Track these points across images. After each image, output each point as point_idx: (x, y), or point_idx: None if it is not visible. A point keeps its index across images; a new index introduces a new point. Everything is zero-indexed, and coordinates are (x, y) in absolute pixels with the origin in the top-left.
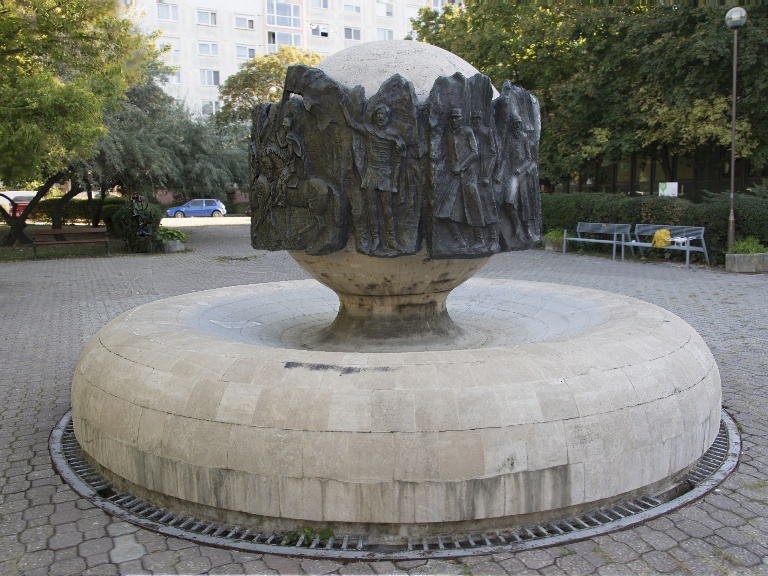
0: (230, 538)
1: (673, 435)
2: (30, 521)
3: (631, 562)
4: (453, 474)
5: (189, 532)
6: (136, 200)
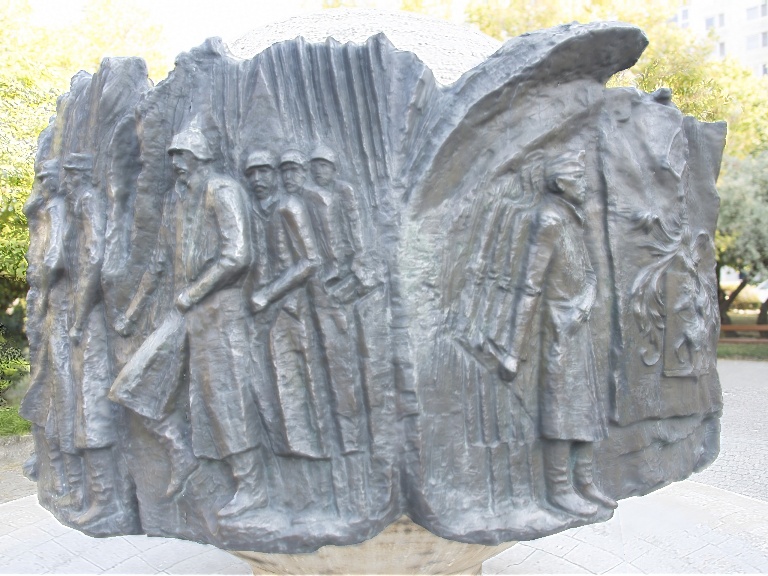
0: None
1: None
2: None
3: None
4: None
5: None
6: None
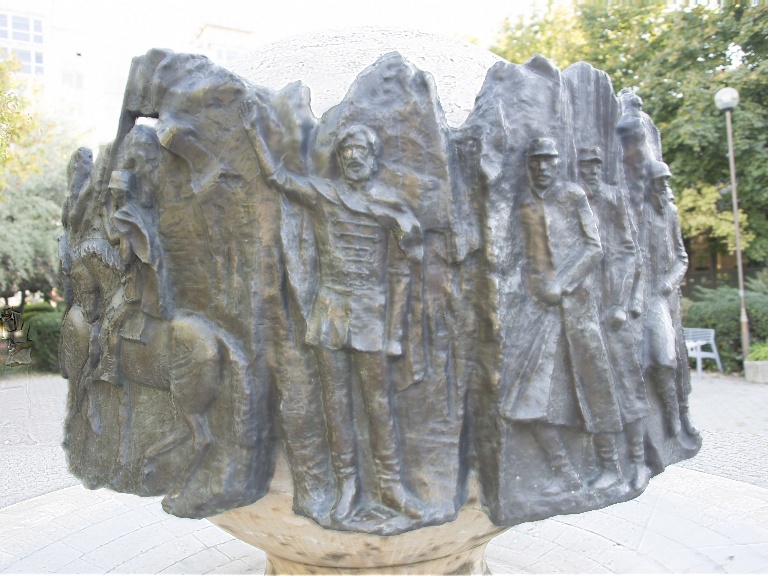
0: None
1: None
2: None
3: None
4: None
5: None
6: (6, 318)
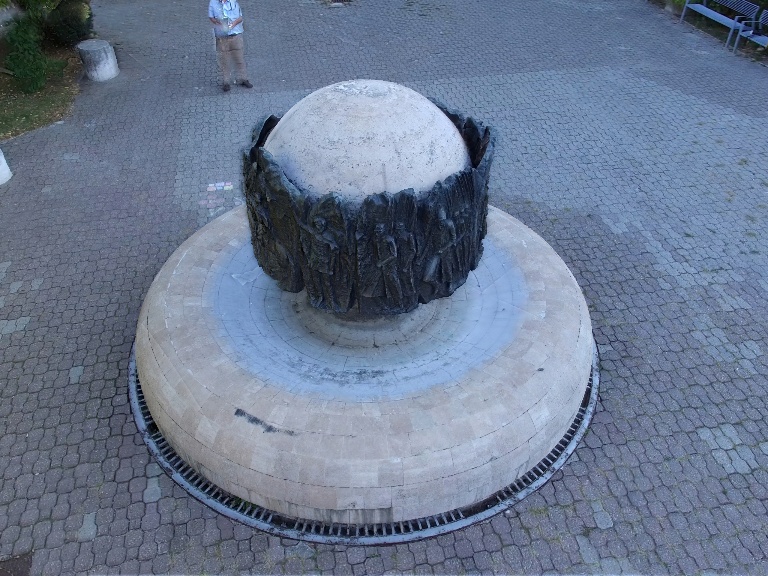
0: (206, 494)
1: (480, 485)
2: (109, 451)
3: (406, 571)
4: (318, 505)
5: (187, 482)
6: (225, 1)
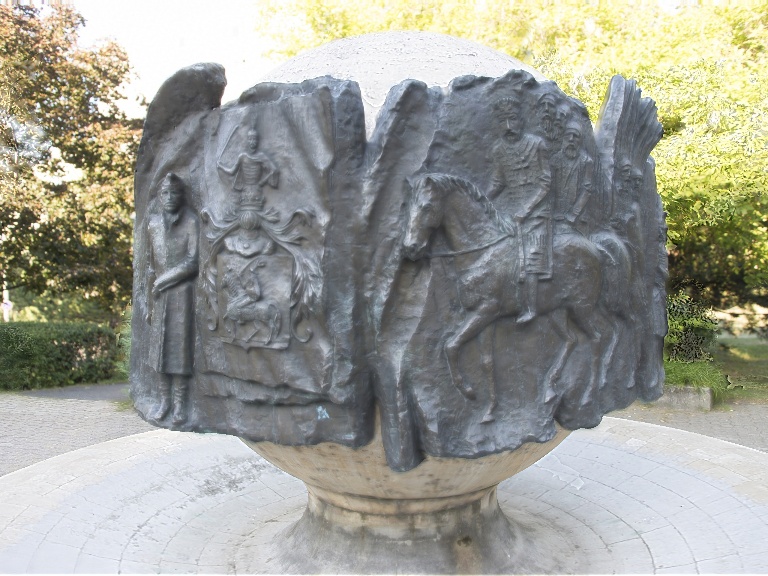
0: None
1: None
2: None
3: None
4: None
5: None
6: None
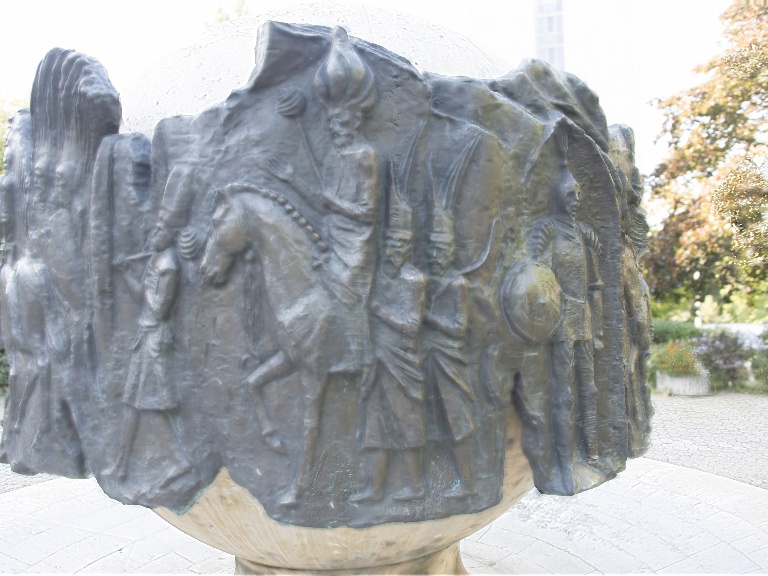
0: None
1: None
2: None
3: None
4: None
5: None
6: None
